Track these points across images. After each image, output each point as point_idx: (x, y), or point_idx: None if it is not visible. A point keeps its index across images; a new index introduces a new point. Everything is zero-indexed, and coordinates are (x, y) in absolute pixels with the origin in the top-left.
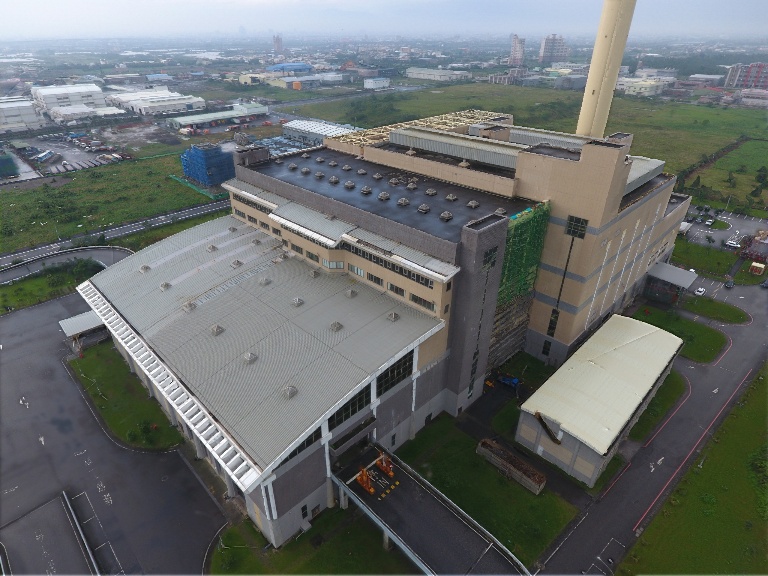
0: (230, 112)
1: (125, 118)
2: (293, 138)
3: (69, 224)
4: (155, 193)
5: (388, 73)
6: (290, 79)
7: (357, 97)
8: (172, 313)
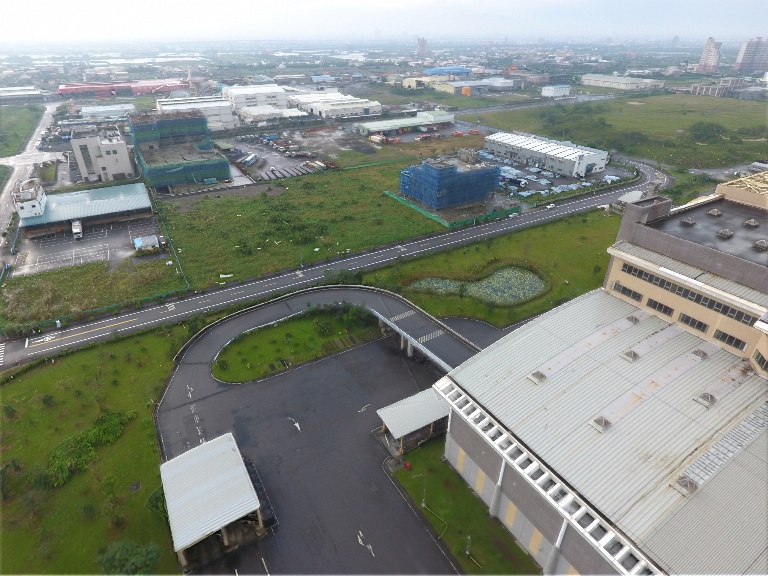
0: (416, 119)
1: (309, 121)
2: (497, 153)
3: (305, 246)
4: (379, 213)
5: (560, 79)
6: (458, 84)
7: (539, 106)
8: (654, 490)
